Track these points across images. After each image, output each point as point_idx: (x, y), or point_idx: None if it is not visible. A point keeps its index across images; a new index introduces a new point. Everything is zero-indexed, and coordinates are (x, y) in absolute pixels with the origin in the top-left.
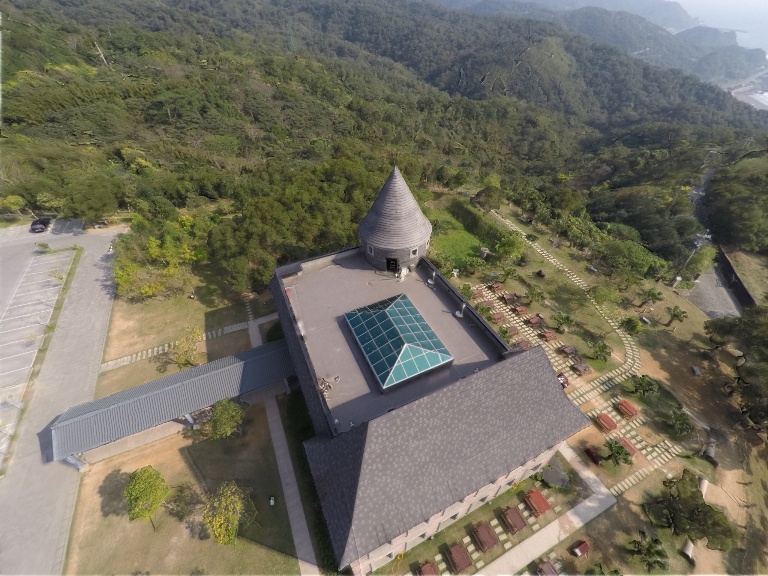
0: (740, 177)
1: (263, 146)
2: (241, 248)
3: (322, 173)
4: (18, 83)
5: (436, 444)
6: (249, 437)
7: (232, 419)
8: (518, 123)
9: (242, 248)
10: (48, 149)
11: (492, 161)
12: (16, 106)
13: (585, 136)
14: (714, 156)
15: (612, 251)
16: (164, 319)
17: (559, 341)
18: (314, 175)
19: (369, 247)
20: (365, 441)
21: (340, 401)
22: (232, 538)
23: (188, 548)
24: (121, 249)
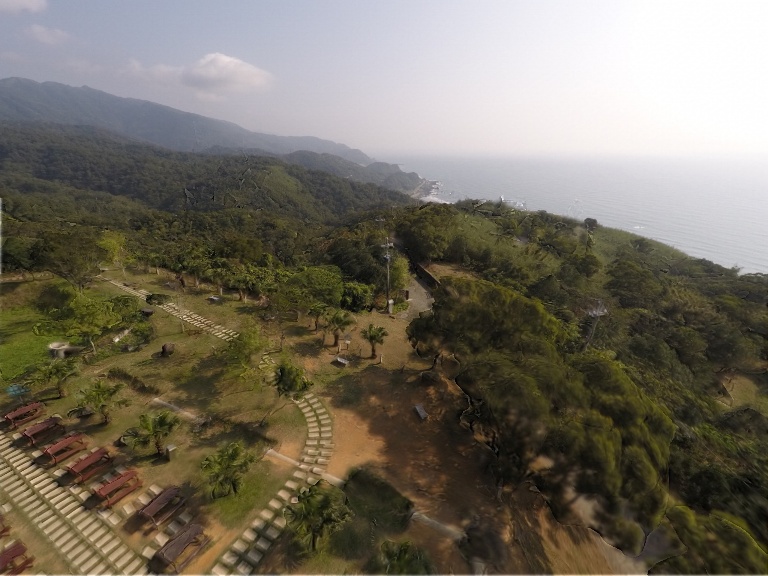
0: (415, 214)
1: None
2: None
3: None
4: None
5: None
6: None
7: None
8: (257, 227)
9: None
10: None
11: None
12: None
13: (321, 230)
14: (397, 209)
15: (291, 286)
16: None
17: (149, 487)
18: None
19: None
20: None
21: None
22: None
23: None
24: None
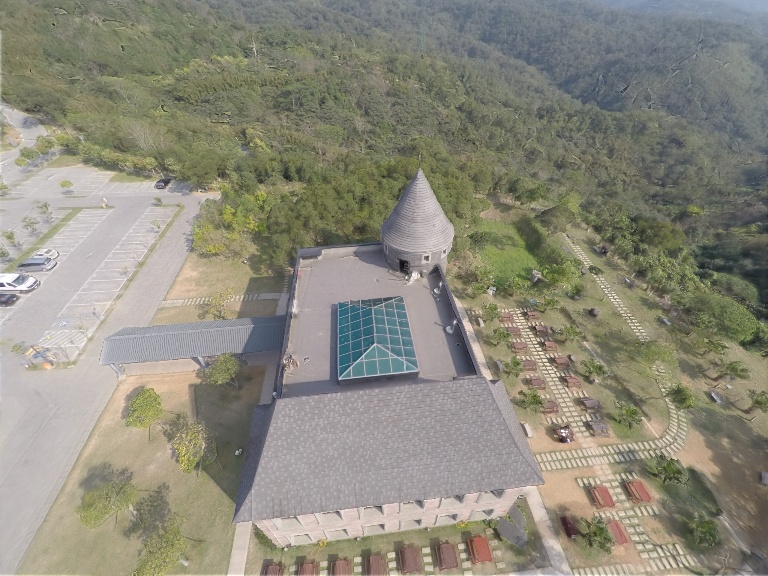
0: None
1: (367, 139)
2: (289, 227)
3: (385, 169)
4: (189, 69)
5: (347, 443)
6: (243, 392)
7: (227, 371)
8: (658, 142)
9: (289, 227)
10: (192, 124)
11: (613, 181)
12: (183, 87)
13: (749, 166)
14: None
15: (699, 306)
16: (218, 276)
17: (583, 391)
18: (377, 170)
19: (385, 245)
20: (272, 416)
21: (299, 380)
22: (190, 469)
23: (165, 465)
24: (204, 211)
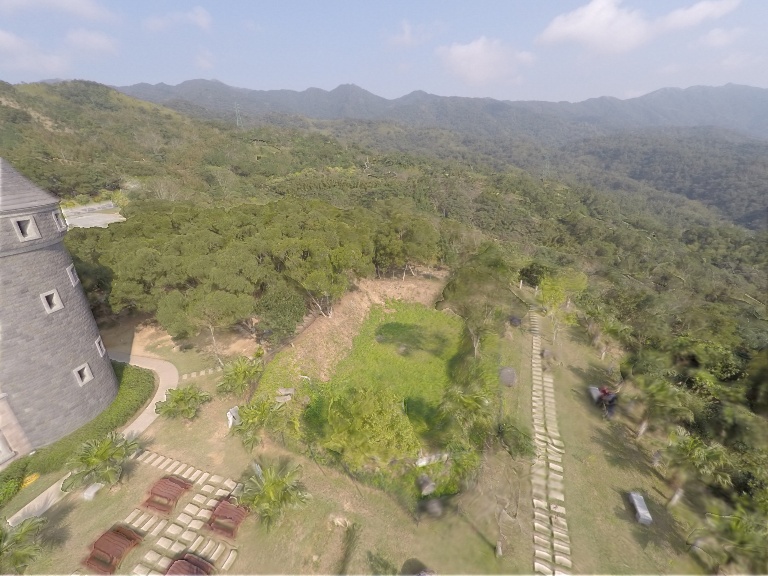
0: None
1: None
2: None
3: (272, 208)
4: (300, 173)
5: None
6: None
7: None
8: None
9: None
10: (256, 203)
11: None
12: None
13: None
14: None
15: None
16: None
17: None
18: (260, 208)
19: None
20: None
21: None
22: None
23: None
24: None
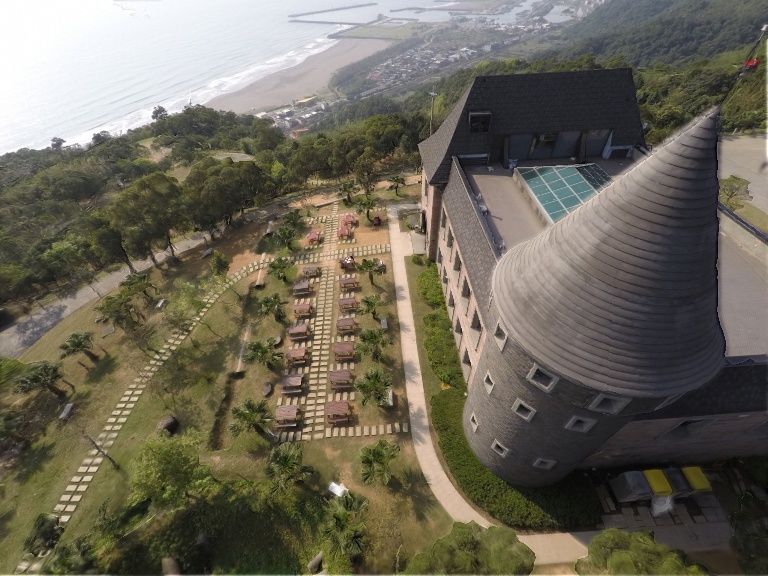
0: None
1: None
2: None
3: None
4: None
5: None
6: None
7: None
8: None
9: None
10: None
11: None
12: None
13: None
14: None
15: None
16: None
17: (297, 304)
18: None
19: None
20: None
21: None
22: None
23: None
24: None
